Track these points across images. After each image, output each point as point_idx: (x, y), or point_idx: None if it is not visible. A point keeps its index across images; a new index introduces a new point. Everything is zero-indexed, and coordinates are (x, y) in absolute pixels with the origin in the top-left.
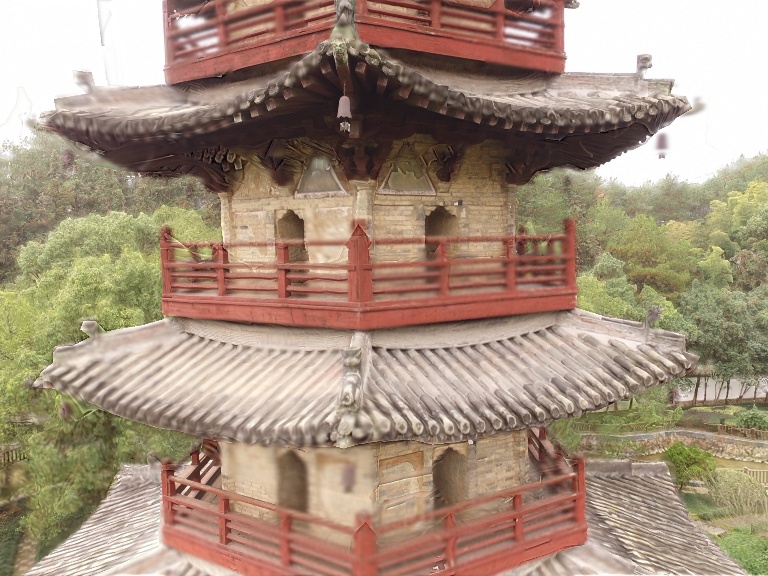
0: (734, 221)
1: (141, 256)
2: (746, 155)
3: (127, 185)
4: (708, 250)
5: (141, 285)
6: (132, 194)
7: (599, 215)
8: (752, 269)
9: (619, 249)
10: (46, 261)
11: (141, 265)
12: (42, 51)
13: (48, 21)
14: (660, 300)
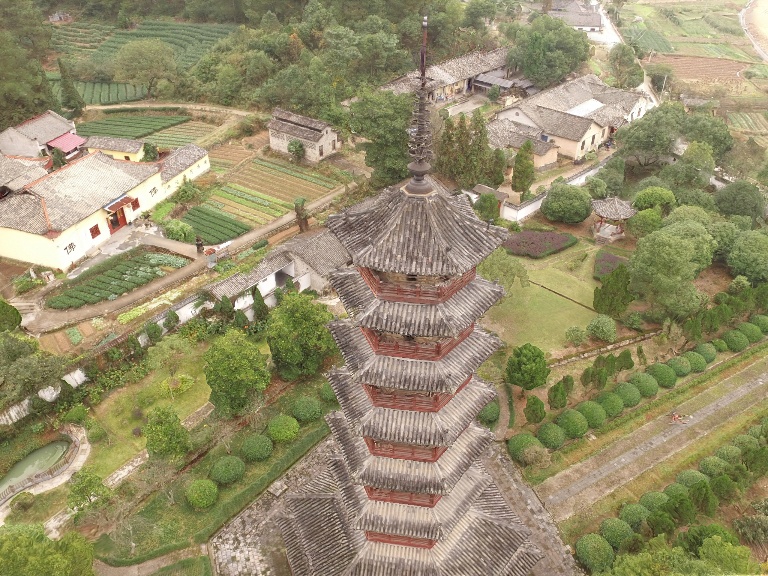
0: None
1: None
2: None
3: None
4: None
5: None
6: None
7: None
8: None
9: None
10: None
11: None
12: None
13: None
14: None
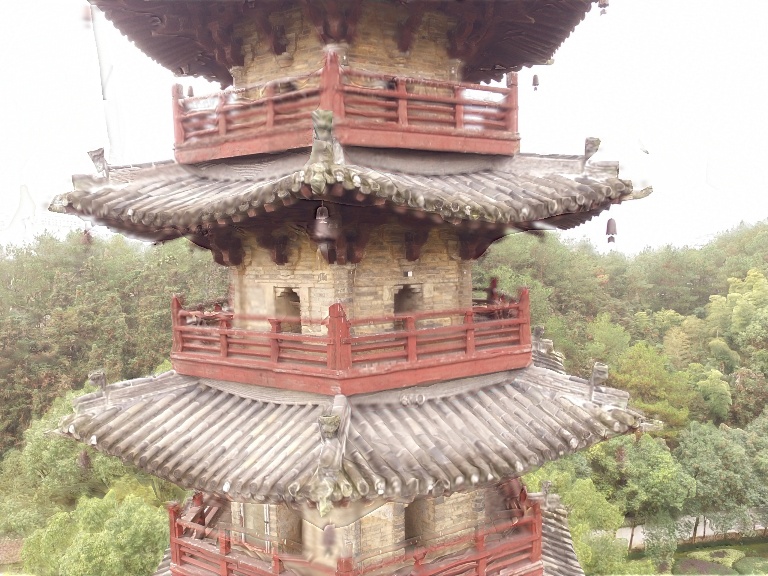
0: (733, 322)
1: (145, 509)
2: (746, 221)
3: (130, 299)
4: (707, 363)
5: (145, 543)
6: (135, 312)
7: (599, 333)
8: (751, 389)
9: (618, 379)
10: (51, 459)
11: (145, 524)
12: (44, 111)
13: (50, 81)
14: (659, 451)
